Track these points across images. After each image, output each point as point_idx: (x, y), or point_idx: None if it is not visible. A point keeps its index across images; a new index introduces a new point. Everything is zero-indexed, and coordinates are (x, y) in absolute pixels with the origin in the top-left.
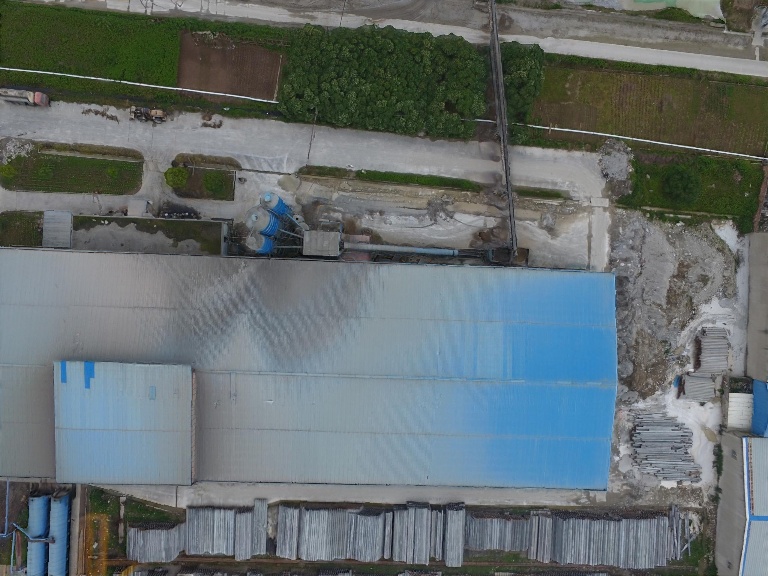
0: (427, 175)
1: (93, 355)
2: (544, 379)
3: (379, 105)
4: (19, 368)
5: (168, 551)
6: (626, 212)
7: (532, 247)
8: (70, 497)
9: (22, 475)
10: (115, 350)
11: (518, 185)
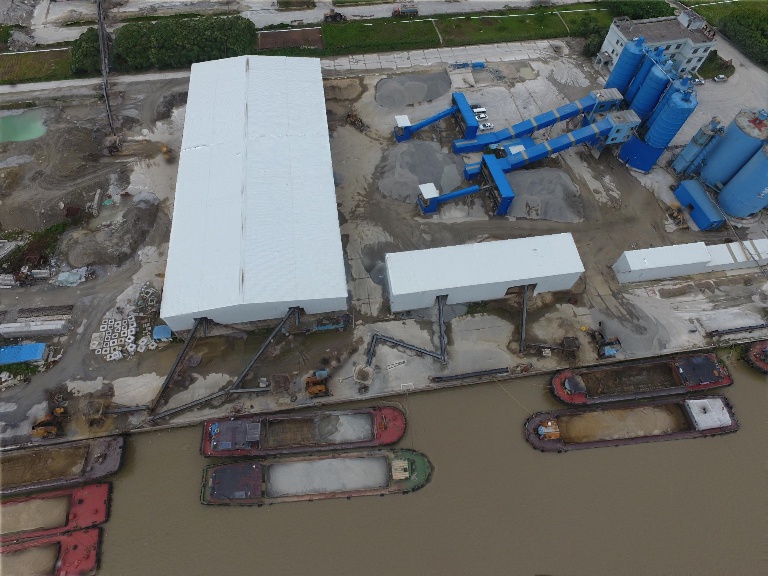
0: None
1: None
2: None
3: None
4: None
5: None
6: None
7: (88, 5)
8: None
9: None
10: None
11: (95, 26)
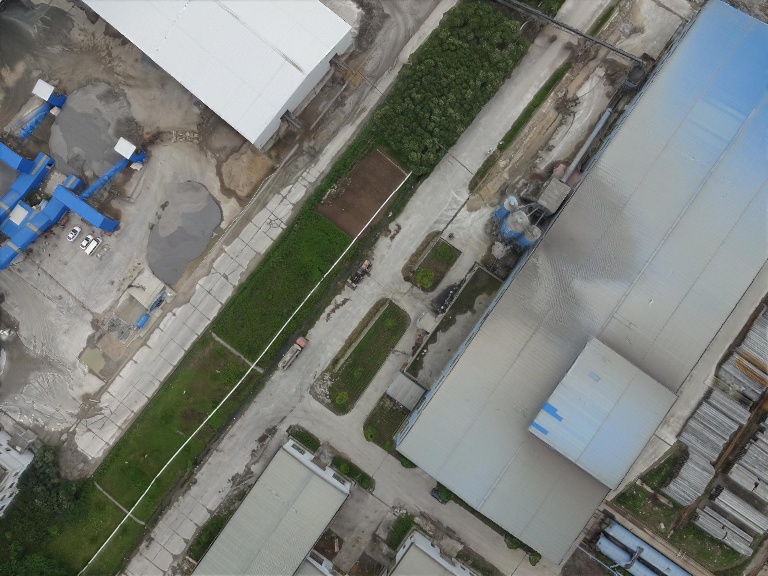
0: (534, 97)
1: (537, 404)
2: (762, 93)
3: (468, 97)
4: (513, 462)
5: (706, 468)
6: None
7: (639, 52)
8: (612, 519)
9: (590, 516)
10: (543, 387)
11: None
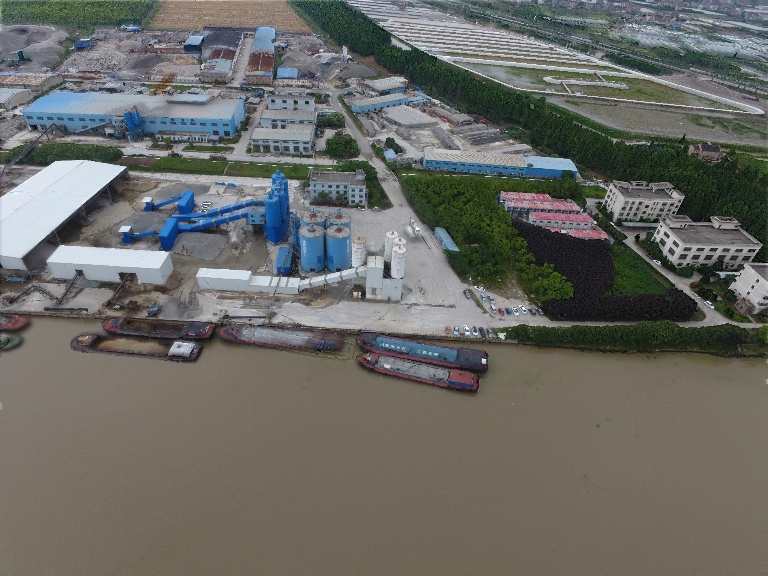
0: None
1: None
2: None
3: None
4: None
5: None
6: (2, 139)
7: None
8: None
9: None
10: None
11: (40, 144)
